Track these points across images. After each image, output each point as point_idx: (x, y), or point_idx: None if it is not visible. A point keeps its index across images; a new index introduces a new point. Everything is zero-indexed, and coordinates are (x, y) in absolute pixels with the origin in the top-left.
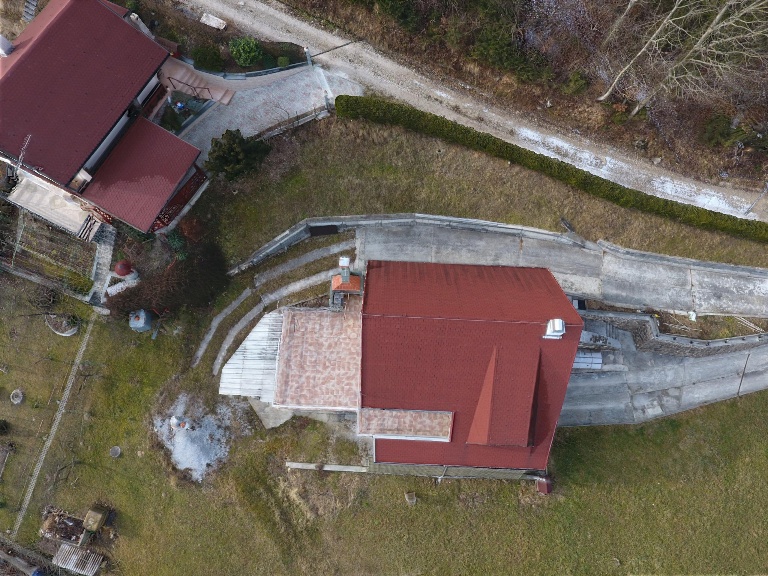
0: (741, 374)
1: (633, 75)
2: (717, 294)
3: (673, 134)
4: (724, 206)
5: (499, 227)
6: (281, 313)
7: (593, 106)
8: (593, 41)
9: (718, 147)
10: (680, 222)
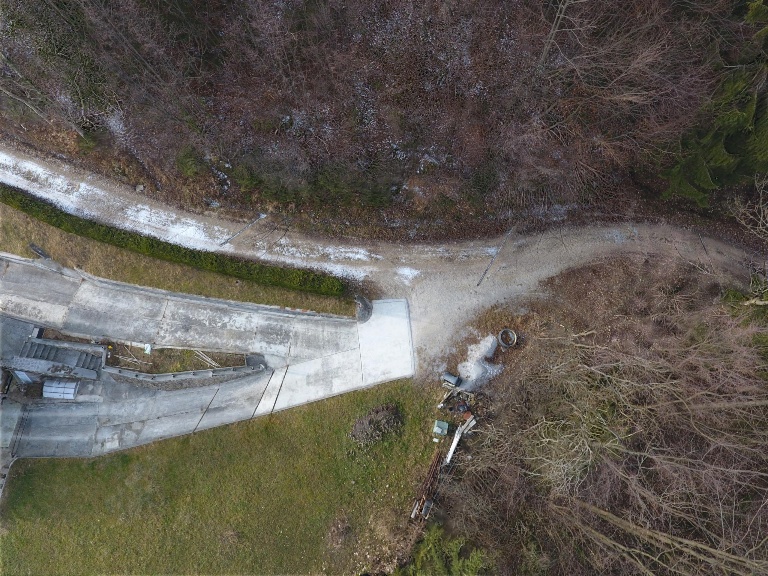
0: (204, 409)
1: (106, 101)
2: (186, 326)
3: (151, 162)
4: (199, 236)
5: None
6: None
7: (61, 131)
8: (57, 66)
9: (198, 176)
10: (136, 252)
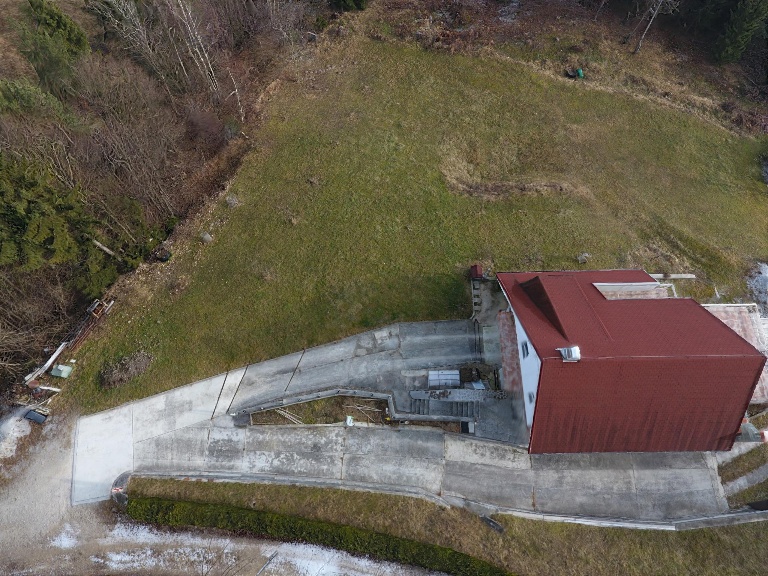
0: (297, 371)
1: None
2: (316, 450)
3: None
4: (302, 563)
5: (571, 517)
6: (767, 405)
7: None
8: None
9: None
10: None
